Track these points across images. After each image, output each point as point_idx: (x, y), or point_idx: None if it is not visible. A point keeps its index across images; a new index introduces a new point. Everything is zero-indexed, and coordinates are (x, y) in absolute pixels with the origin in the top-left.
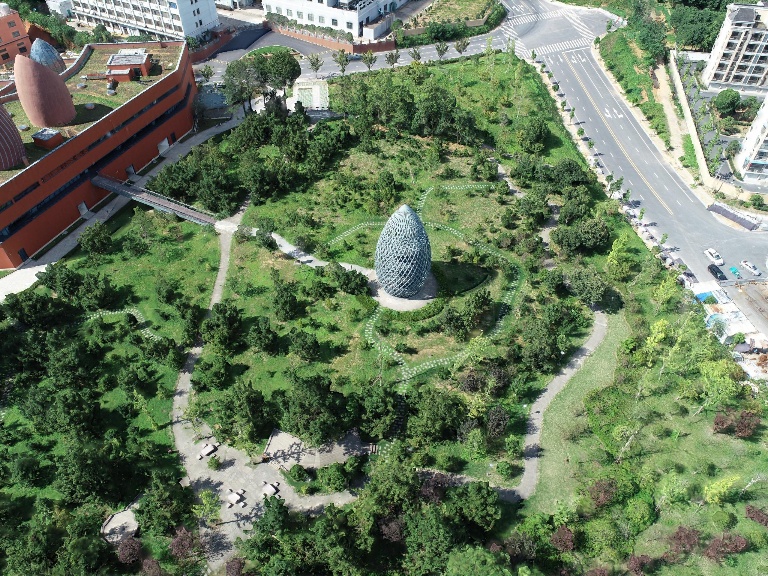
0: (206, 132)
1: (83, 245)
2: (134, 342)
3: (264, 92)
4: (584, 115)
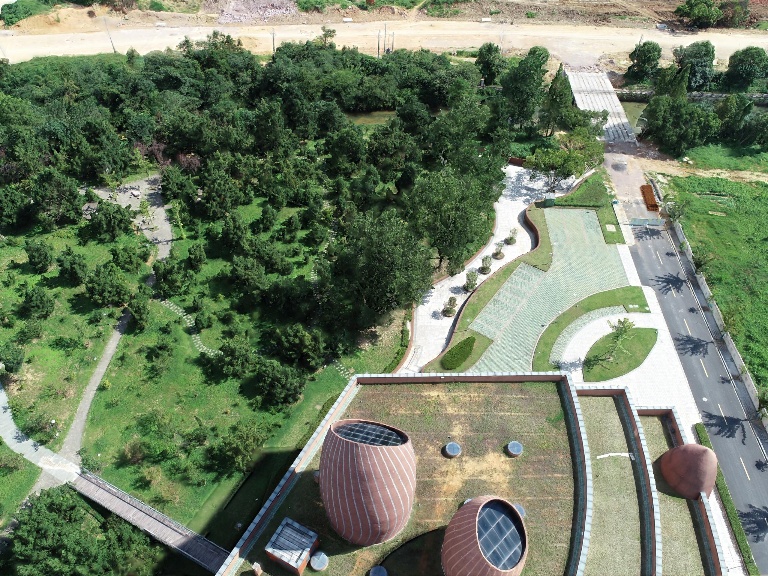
0: None
1: None
2: None
3: None
4: None
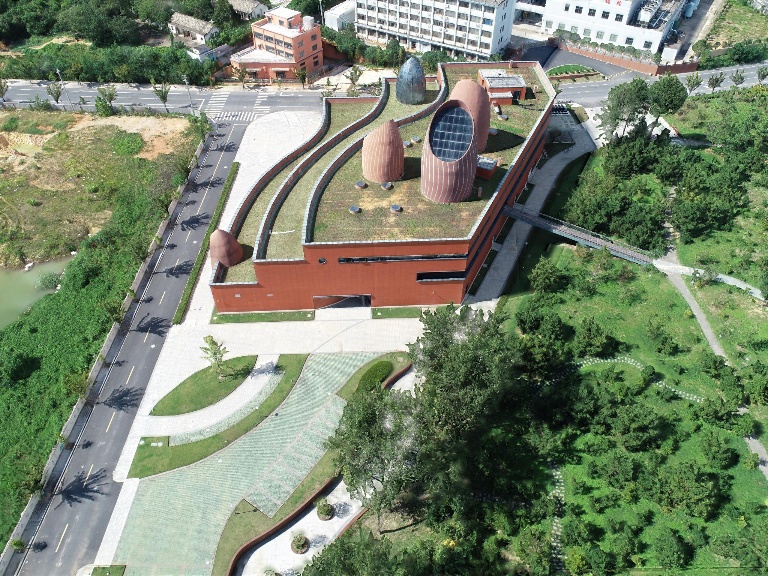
0: (558, 157)
1: (533, 282)
2: (667, 398)
3: (629, 118)
4: None
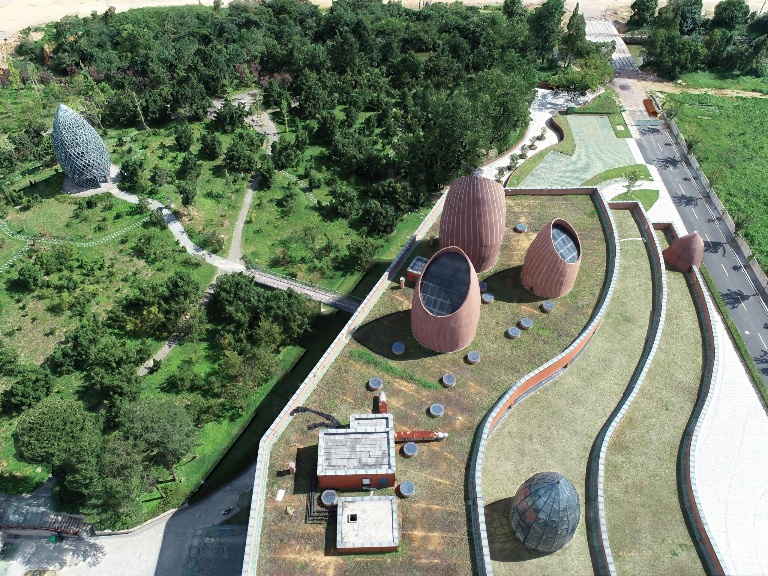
0: None
1: None
2: None
3: None
4: None
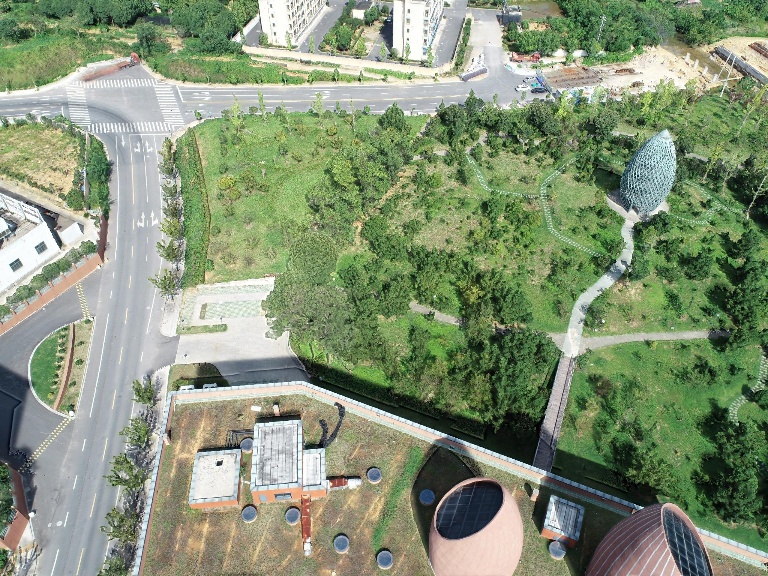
0: None
1: None
2: None
3: None
4: (322, 108)
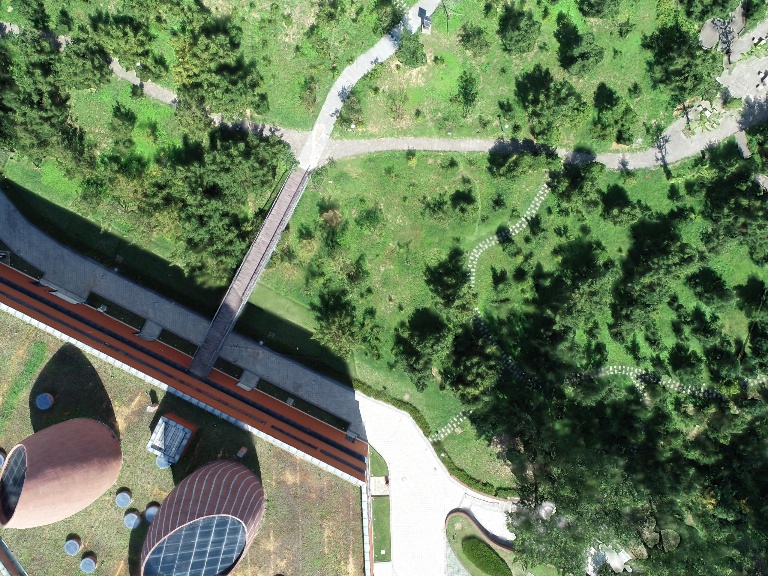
0: (7, 235)
1: (350, 352)
2: None
3: None
4: None
